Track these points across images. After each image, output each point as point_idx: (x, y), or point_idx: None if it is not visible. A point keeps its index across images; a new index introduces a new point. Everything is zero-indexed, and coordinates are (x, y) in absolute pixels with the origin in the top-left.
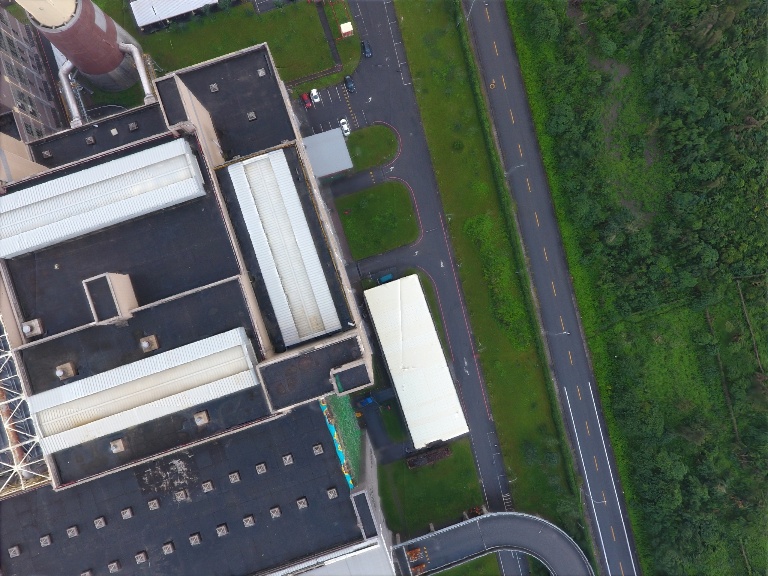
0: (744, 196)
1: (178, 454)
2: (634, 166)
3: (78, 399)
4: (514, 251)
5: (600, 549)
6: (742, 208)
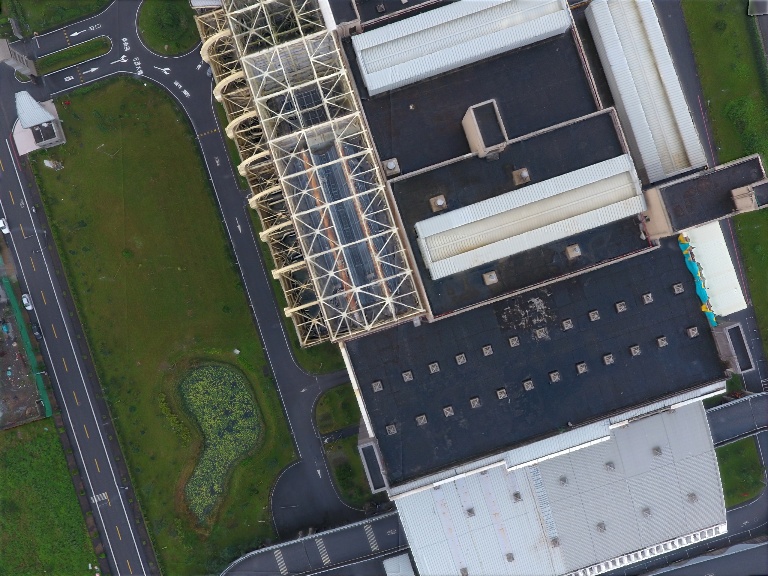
0: None
1: (537, 292)
2: None
3: (465, 225)
4: None
5: None
6: None
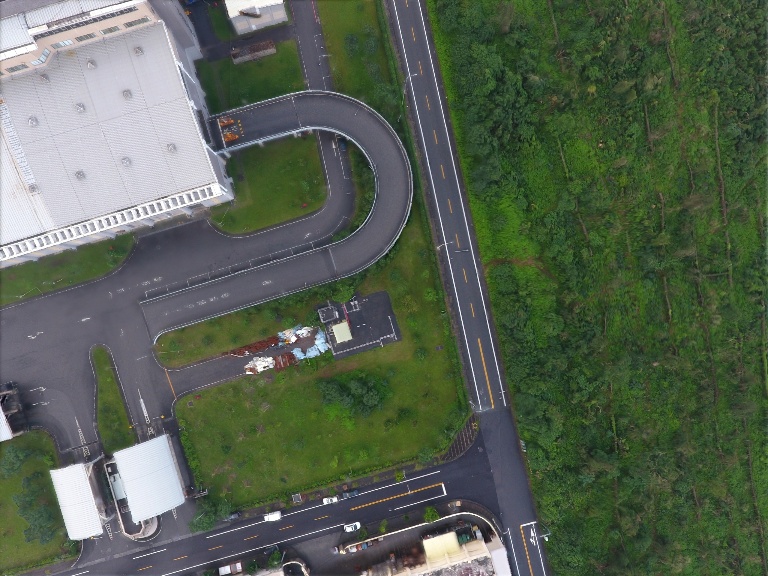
0: None
1: None
2: None
3: None
4: None
5: (422, 151)
6: None
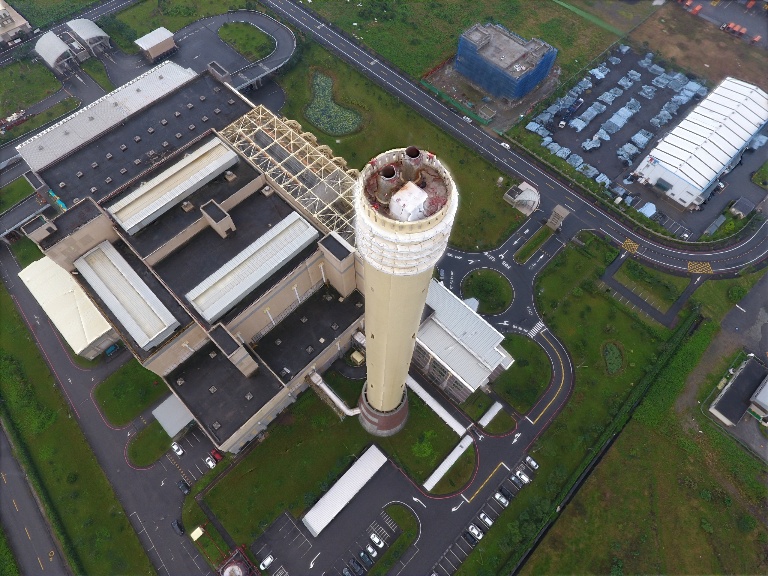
0: None
1: None
2: None
3: None
4: (8, 416)
5: None
6: None
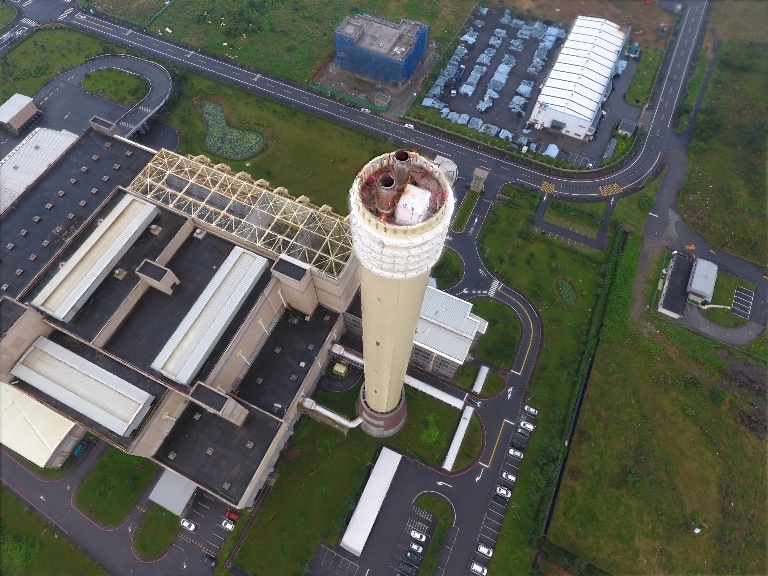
0: None
1: None
2: None
3: None
4: None
5: None
6: None
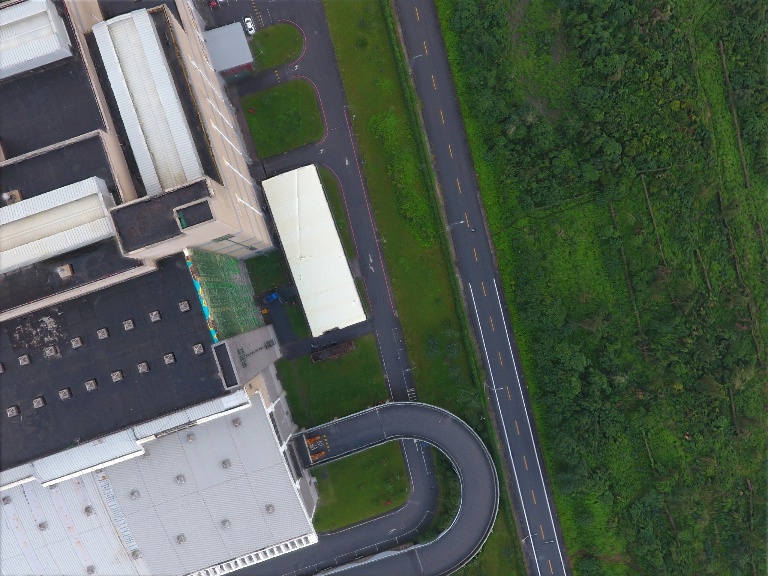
0: (649, 89)
1: (48, 311)
2: (541, 63)
3: None
4: (418, 147)
5: (504, 443)
6: (647, 102)
